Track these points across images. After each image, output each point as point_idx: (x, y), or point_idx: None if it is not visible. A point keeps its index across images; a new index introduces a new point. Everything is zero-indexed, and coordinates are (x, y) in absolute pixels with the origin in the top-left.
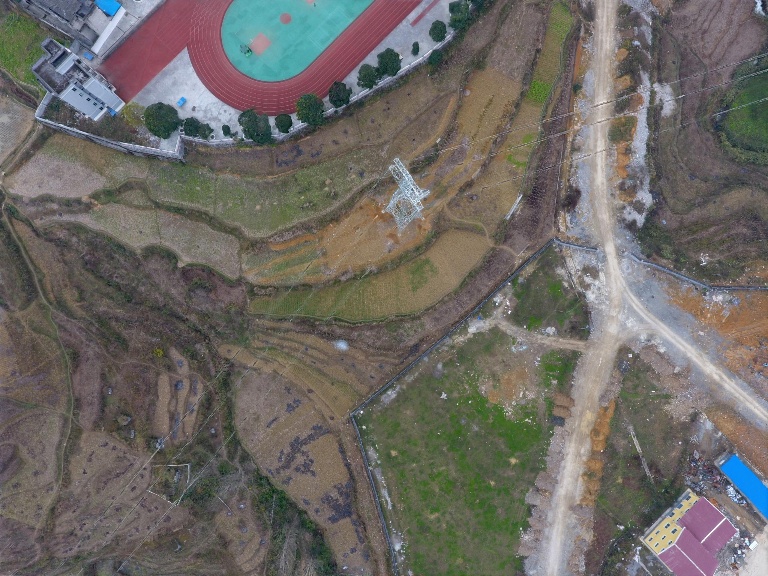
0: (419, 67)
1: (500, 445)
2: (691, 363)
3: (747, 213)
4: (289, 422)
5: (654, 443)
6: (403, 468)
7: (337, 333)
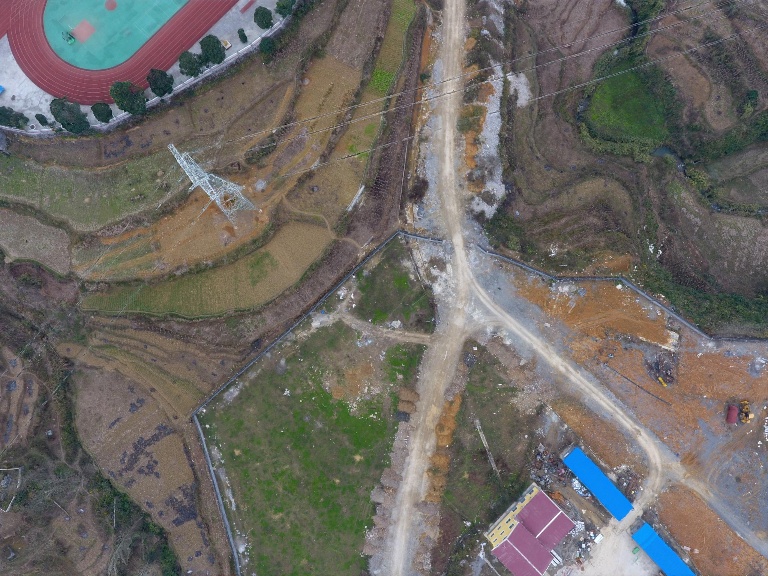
0: (251, 55)
1: (344, 442)
2: (537, 355)
3: (598, 203)
4: (132, 422)
5: (501, 437)
6: (247, 467)
7: (175, 329)
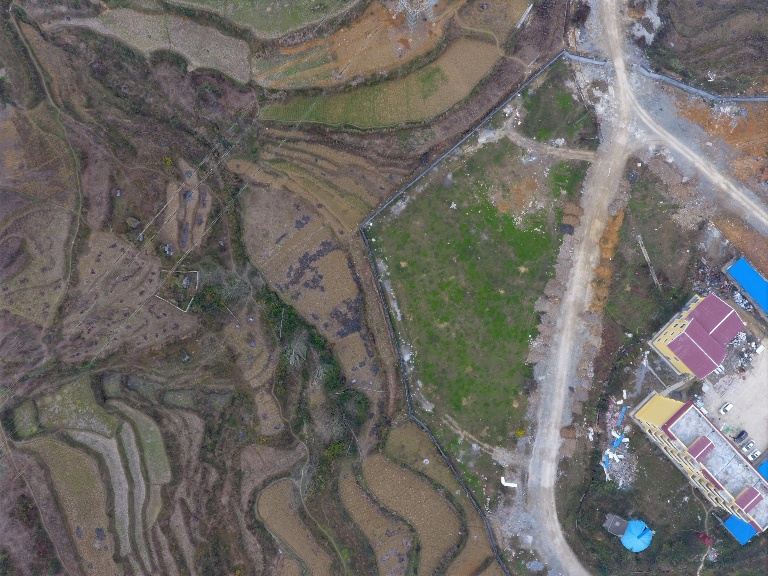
0: None
1: (509, 254)
2: (699, 173)
3: (754, 34)
4: (298, 238)
5: (662, 252)
6: (412, 279)
7: (347, 141)
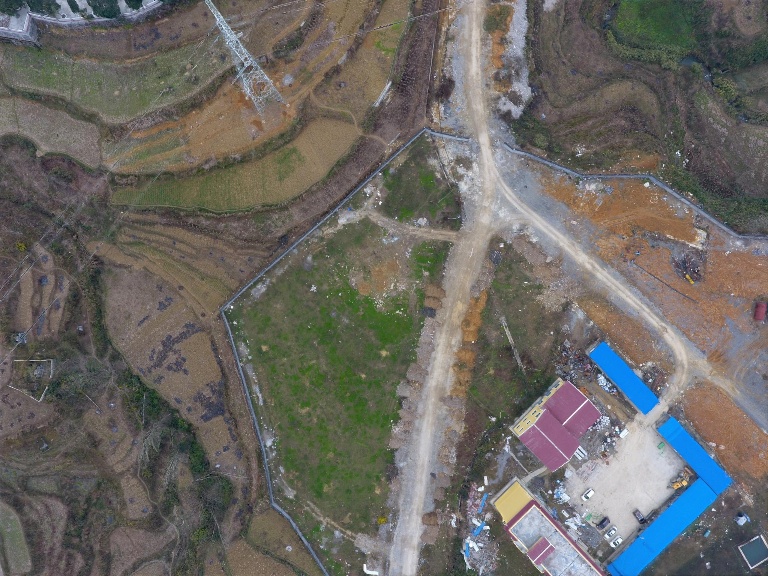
0: None
1: (370, 337)
2: (563, 252)
3: (625, 105)
4: (161, 320)
5: (526, 334)
6: (274, 363)
7: (203, 224)
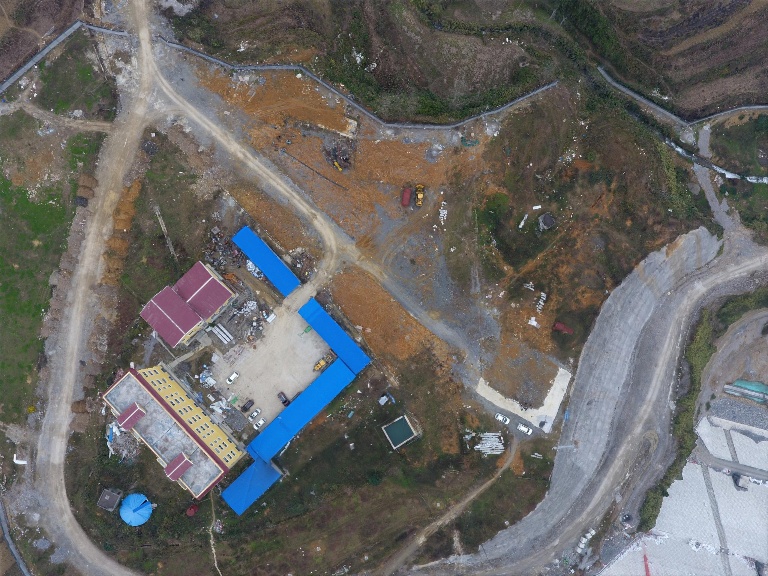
0: None
1: (23, 227)
2: (215, 142)
3: (292, 4)
4: None
5: (180, 222)
6: None
7: None
